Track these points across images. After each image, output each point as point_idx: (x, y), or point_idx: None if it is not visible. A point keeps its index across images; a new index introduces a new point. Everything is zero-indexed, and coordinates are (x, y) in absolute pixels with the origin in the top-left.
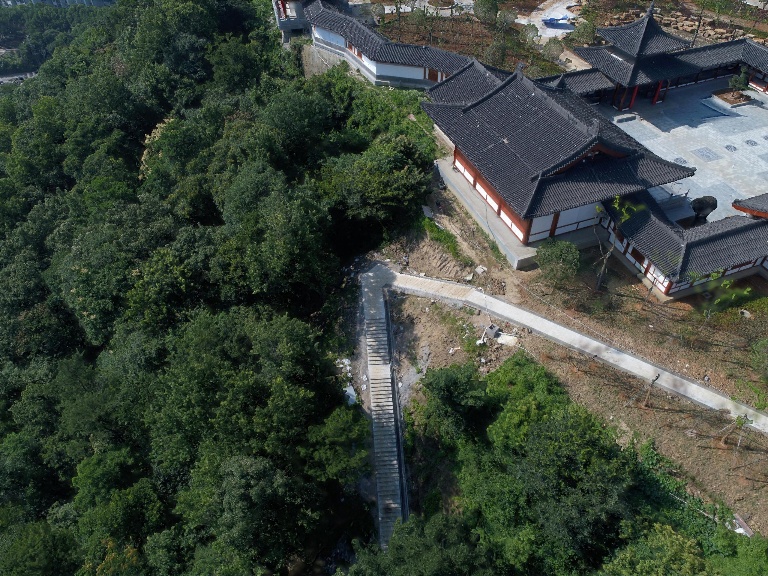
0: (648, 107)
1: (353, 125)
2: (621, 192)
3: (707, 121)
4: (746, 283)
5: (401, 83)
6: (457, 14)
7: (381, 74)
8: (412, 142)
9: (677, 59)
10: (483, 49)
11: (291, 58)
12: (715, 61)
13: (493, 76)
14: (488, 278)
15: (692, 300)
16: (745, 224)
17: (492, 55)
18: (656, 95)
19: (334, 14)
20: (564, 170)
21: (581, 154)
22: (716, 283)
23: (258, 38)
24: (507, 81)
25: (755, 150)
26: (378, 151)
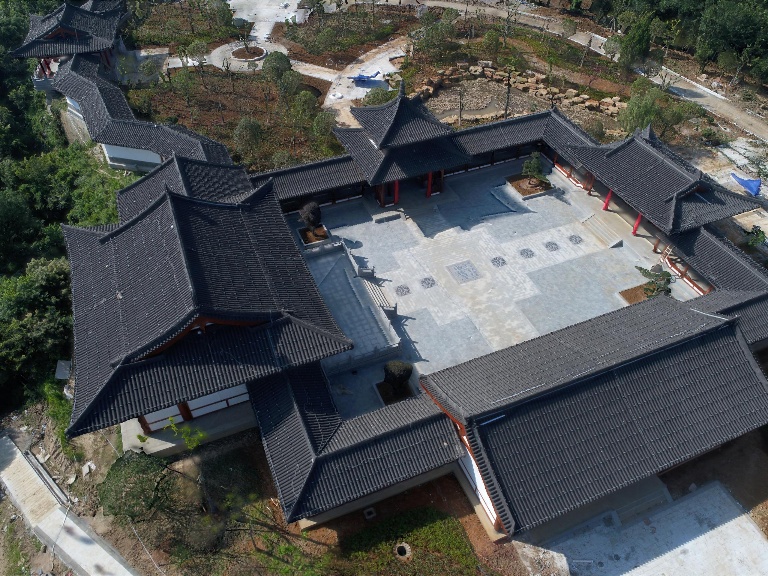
0: (420, 201)
1: (72, 221)
2: (241, 379)
3: (486, 220)
4: (429, 491)
5: (138, 167)
6: (259, 68)
7: (114, 156)
8: (65, 271)
9: (444, 146)
10: (259, 118)
11: (51, 124)
12: (508, 141)
13: (181, 181)
14: (89, 484)
15: (344, 524)
16: (412, 421)
17: (240, 135)
18: (428, 187)
19: (79, 78)
20: (161, 351)
21: (178, 331)
22: (386, 494)
23: (18, 99)
24: (155, 203)
25: (527, 264)
26: (4, 289)
